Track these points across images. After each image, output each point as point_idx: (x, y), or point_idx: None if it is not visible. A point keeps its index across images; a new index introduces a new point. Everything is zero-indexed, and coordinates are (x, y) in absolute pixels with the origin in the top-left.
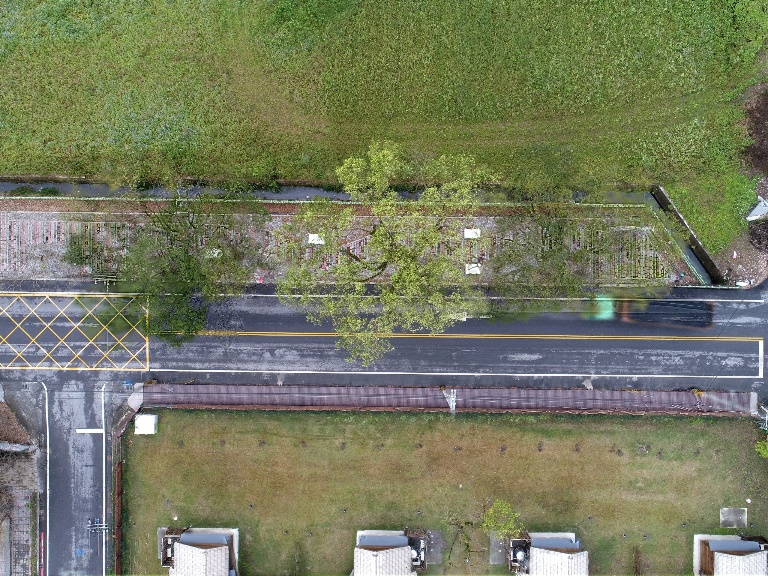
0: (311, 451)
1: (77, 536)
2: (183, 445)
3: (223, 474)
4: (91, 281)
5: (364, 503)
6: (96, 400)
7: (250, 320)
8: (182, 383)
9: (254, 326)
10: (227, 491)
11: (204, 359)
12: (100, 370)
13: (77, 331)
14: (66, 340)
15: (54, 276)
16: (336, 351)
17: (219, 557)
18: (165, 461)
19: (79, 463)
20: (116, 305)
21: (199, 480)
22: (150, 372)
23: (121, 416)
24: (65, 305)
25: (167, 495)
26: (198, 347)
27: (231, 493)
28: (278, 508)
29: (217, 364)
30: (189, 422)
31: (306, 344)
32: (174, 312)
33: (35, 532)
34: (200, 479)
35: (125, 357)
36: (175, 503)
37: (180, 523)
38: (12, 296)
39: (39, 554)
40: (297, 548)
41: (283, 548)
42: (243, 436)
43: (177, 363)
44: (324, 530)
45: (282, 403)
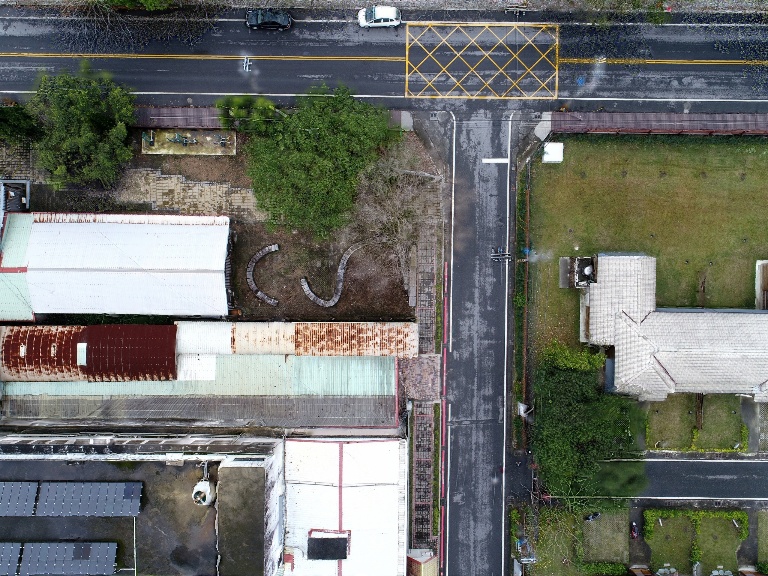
0: (711, 182)
1: (481, 265)
2: (585, 176)
3: (624, 205)
4: (501, 11)
5: (763, 233)
6: (503, 129)
7: (659, 48)
8: (590, 111)
9: (663, 54)
10: (628, 221)
11: (612, 87)
12: (509, 99)
13: (487, 60)
14: (476, 69)
15: (465, 6)
16: (743, 79)
17: (649, 266)
18: (567, 192)
19: (484, 193)
20: (526, 34)
21: (600, 211)
22: (558, 100)
23: (527, 146)
24: (476, 34)
25: (569, 225)
26: (607, 75)
27: (632, 223)
28: (679, 238)
29: (625, 92)
30: (592, 153)
31: (714, 72)
32: (583, 41)
33: (440, 261)
34: (601, 210)
35: (534, 85)
36: (577, 233)
37: (581, 253)
38: (424, 26)
39: (443, 283)
40: (698, 276)
41: (683, 277)
42: (644, 167)
43: (585, 91)
44: (724, 260)
45: (691, 129)
